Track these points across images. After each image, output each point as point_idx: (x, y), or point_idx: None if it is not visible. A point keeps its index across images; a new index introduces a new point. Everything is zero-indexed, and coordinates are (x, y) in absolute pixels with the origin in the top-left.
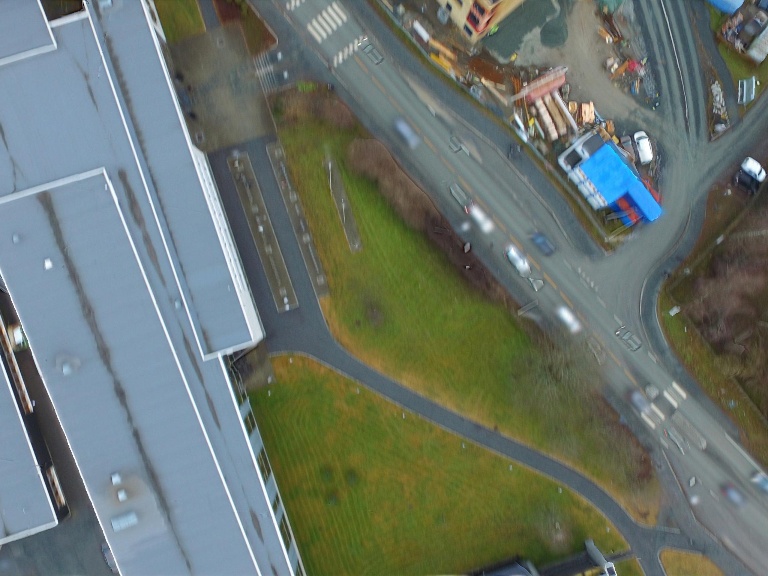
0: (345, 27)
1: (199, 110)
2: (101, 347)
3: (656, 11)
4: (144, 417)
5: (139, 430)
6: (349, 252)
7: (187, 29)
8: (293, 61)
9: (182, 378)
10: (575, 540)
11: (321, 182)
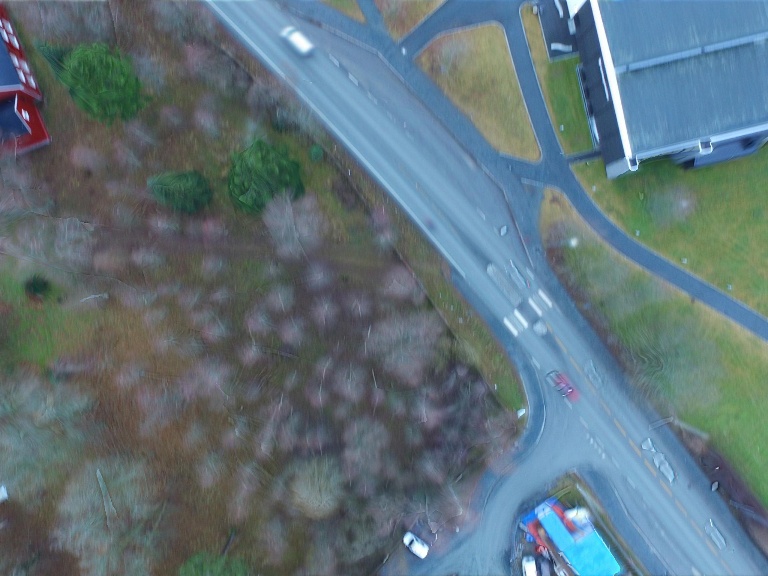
0: None
1: None
2: None
3: None
4: None
5: None
6: None
7: None
8: None
9: None
10: (626, 180)
11: None
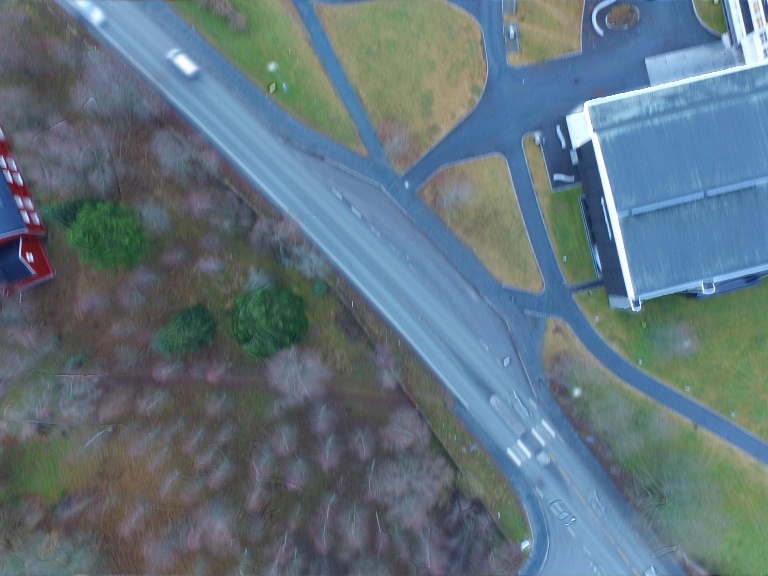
0: None
1: None
2: None
3: None
4: None
5: None
6: None
7: None
8: None
9: None
10: (629, 309)
11: None
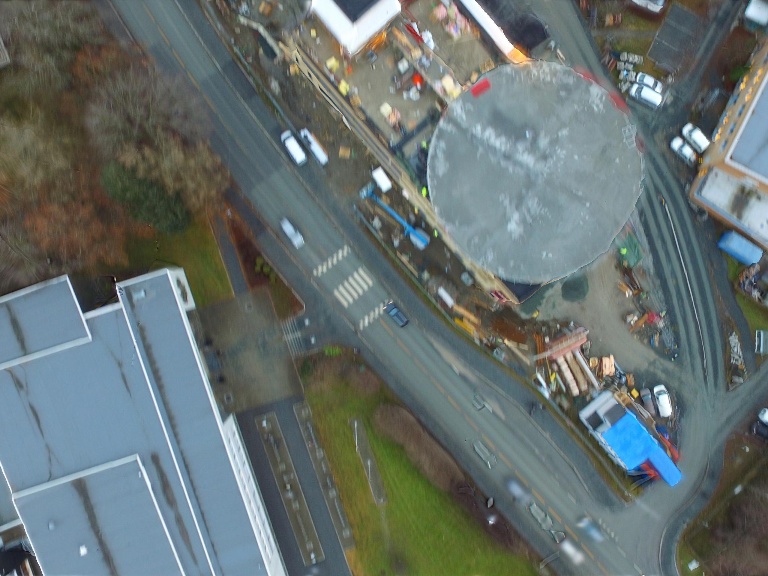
0: (371, 291)
1: (228, 373)
2: None
3: (675, 265)
4: None
5: None
6: (374, 506)
7: (216, 294)
8: (320, 326)
9: None
10: None
11: (347, 439)
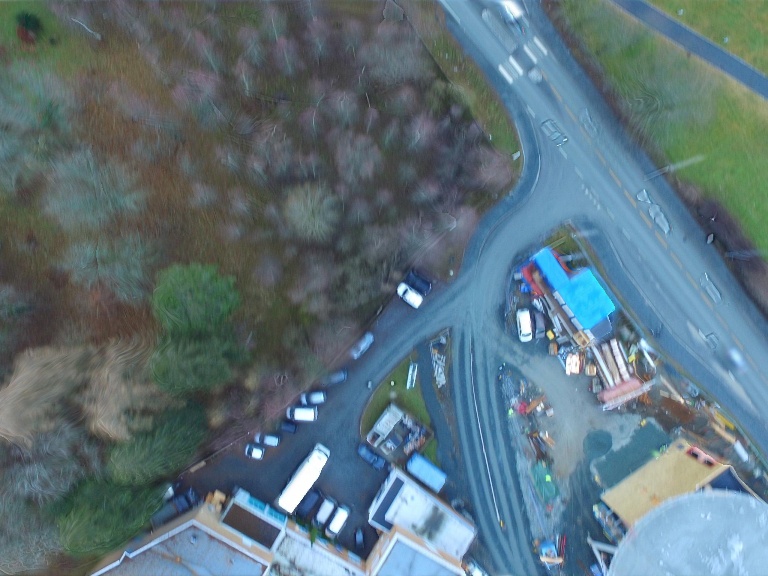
0: None
1: None
2: None
3: (495, 460)
4: None
5: None
6: None
7: None
8: None
9: None
10: None
11: None
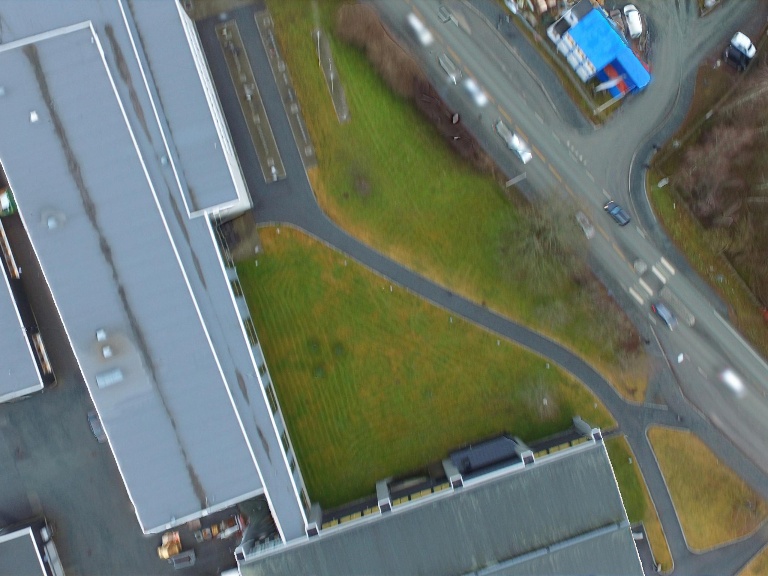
0: None
1: None
2: (87, 203)
3: None
4: (130, 274)
5: (124, 287)
6: (337, 123)
7: None
8: None
9: (168, 235)
10: (563, 417)
11: (309, 52)
